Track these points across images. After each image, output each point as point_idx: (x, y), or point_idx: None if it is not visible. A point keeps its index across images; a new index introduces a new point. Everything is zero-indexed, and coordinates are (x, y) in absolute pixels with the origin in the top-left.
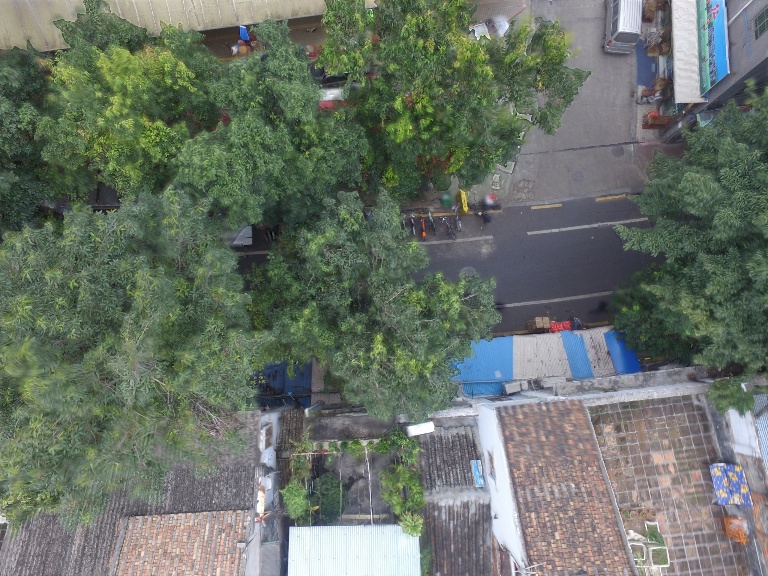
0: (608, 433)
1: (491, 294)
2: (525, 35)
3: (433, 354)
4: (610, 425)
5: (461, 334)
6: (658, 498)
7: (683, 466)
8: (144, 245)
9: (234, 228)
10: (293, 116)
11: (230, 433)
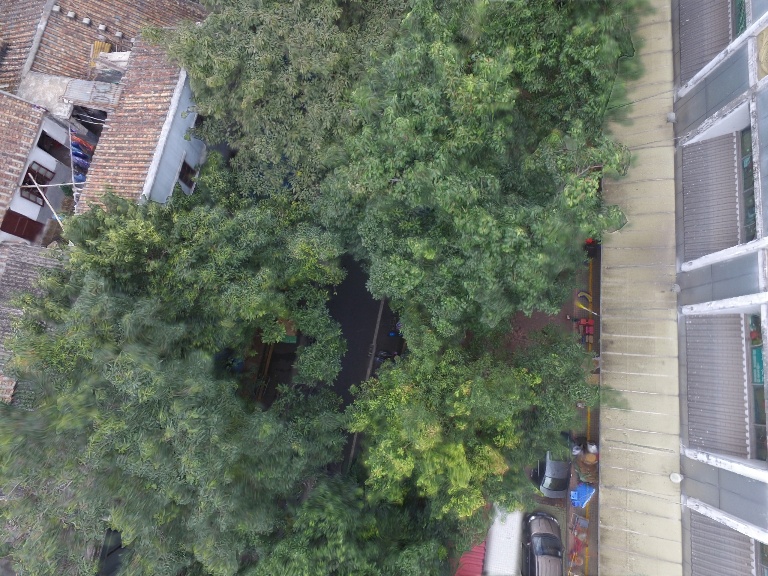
0: None
1: None
2: None
3: None
4: None
5: None
6: None
7: None
8: (241, 462)
9: (255, 544)
10: None
11: (5, 540)
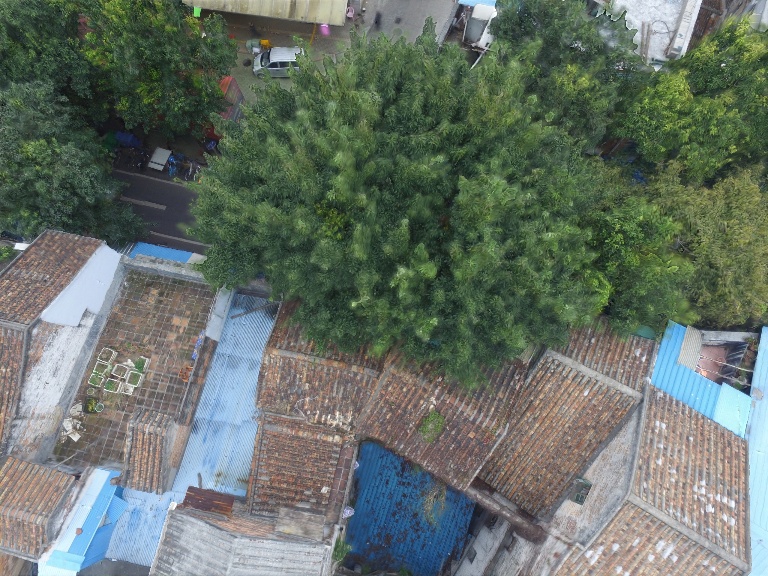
0: (152, 294)
1: (78, 159)
2: (158, 8)
3: (3, 171)
4: (157, 290)
5: (64, 186)
6: (161, 345)
7: (190, 331)
8: None
9: None
10: (7, 19)
11: None
